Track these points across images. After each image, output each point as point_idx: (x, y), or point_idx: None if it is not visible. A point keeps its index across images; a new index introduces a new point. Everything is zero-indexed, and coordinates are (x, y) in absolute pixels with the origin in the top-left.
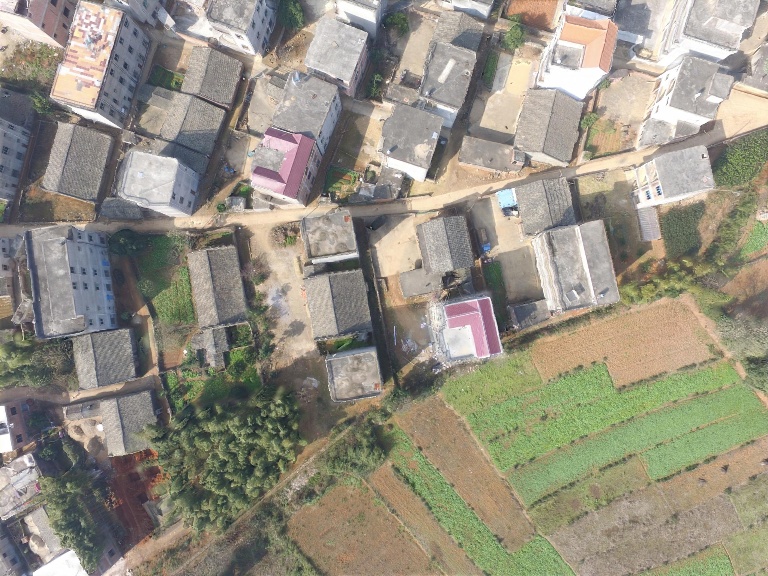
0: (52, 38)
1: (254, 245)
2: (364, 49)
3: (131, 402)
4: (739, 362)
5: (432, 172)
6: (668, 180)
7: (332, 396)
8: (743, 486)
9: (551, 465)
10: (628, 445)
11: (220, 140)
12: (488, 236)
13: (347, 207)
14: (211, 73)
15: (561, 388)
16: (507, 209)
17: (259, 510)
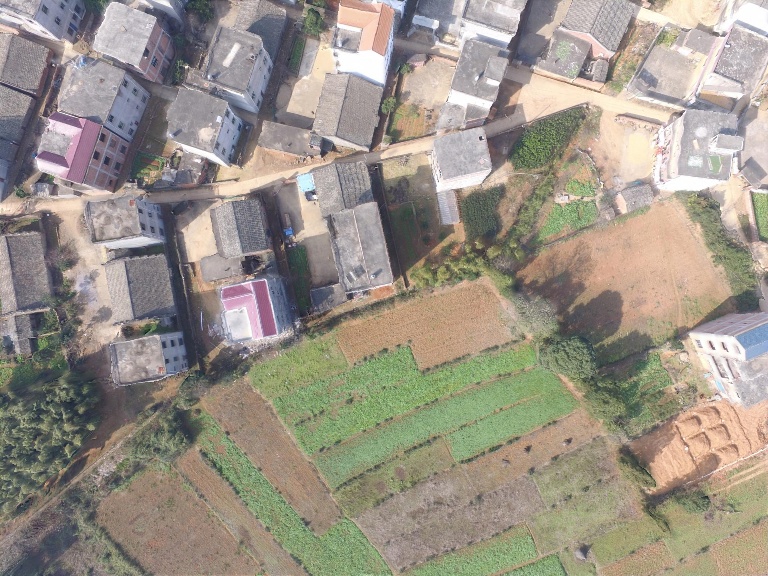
0: None
1: (63, 232)
2: (159, 34)
3: None
4: (537, 343)
5: (236, 157)
6: (446, 162)
7: (115, 380)
8: (546, 466)
9: (356, 448)
10: (432, 427)
11: (30, 127)
12: (294, 221)
13: (155, 193)
14: (13, 59)
15: (366, 371)
16: (309, 193)
17: (64, 497)
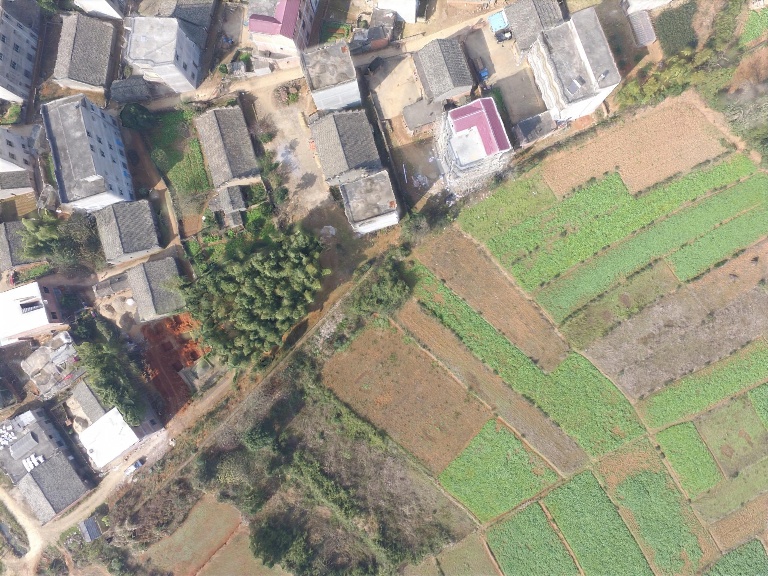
0: None
1: (259, 108)
2: None
3: (157, 267)
4: (753, 149)
5: (422, 11)
6: None
7: (349, 218)
8: None
9: (577, 280)
10: (652, 250)
11: (216, 15)
12: (484, 65)
13: None
14: None
15: (576, 202)
16: (499, 34)
17: (292, 359)
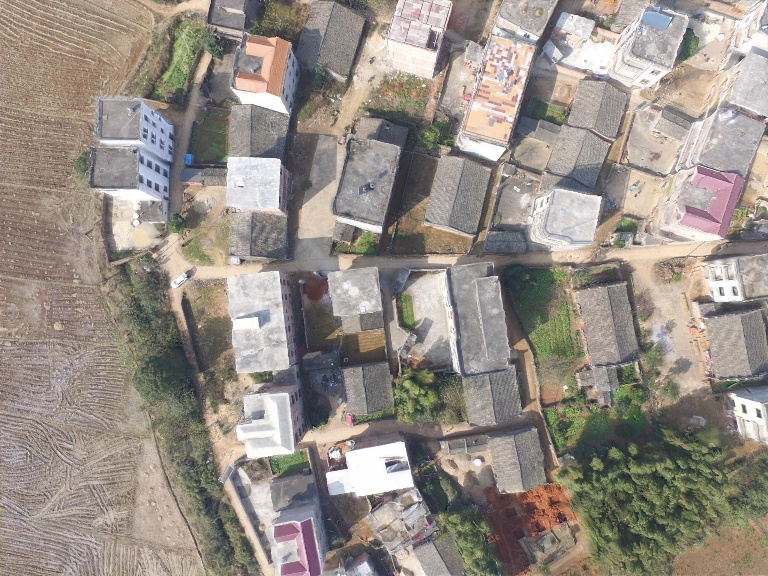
0: (433, 70)
1: (636, 280)
2: None
3: (524, 439)
4: None
5: None
6: None
7: None
8: None
9: None
10: None
11: None
12: None
13: (734, 243)
14: (604, 107)
15: None
16: None
17: None
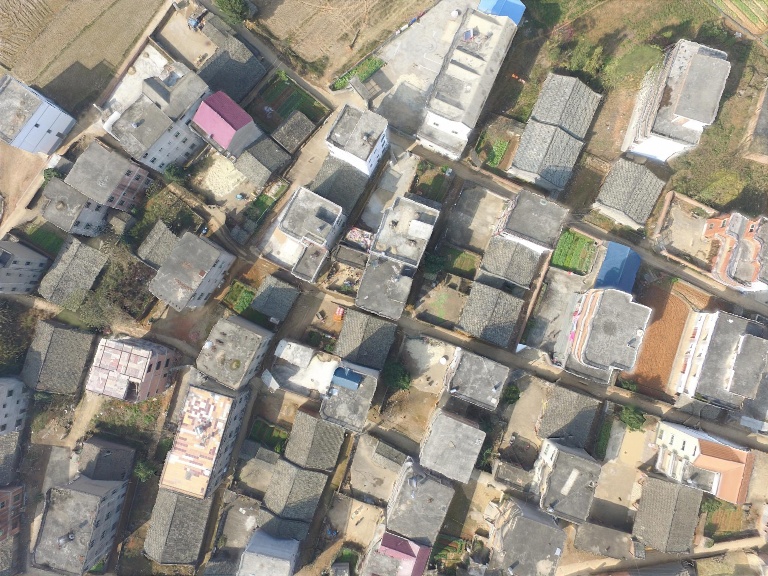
0: None
1: None
2: None
3: None
4: None
5: None
6: None
7: None
8: None
9: None
10: None
11: (322, 498)
12: None
13: None
14: (317, 443)
15: None
16: None
17: None
